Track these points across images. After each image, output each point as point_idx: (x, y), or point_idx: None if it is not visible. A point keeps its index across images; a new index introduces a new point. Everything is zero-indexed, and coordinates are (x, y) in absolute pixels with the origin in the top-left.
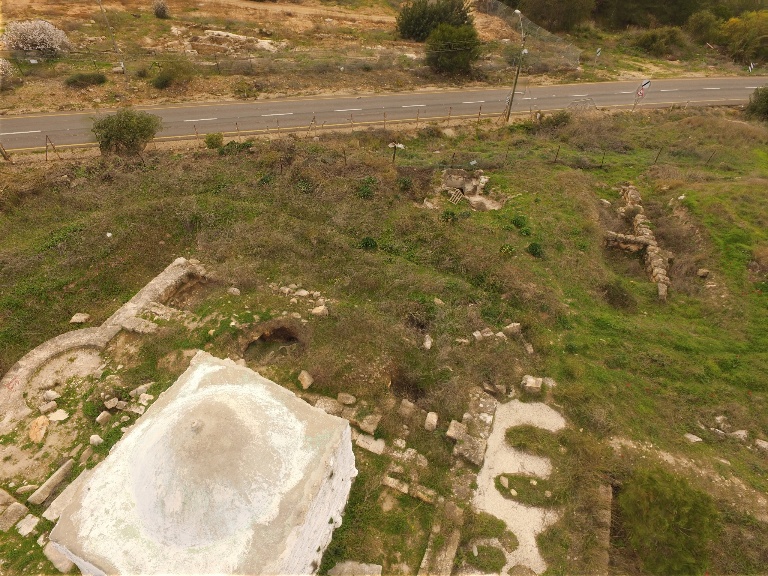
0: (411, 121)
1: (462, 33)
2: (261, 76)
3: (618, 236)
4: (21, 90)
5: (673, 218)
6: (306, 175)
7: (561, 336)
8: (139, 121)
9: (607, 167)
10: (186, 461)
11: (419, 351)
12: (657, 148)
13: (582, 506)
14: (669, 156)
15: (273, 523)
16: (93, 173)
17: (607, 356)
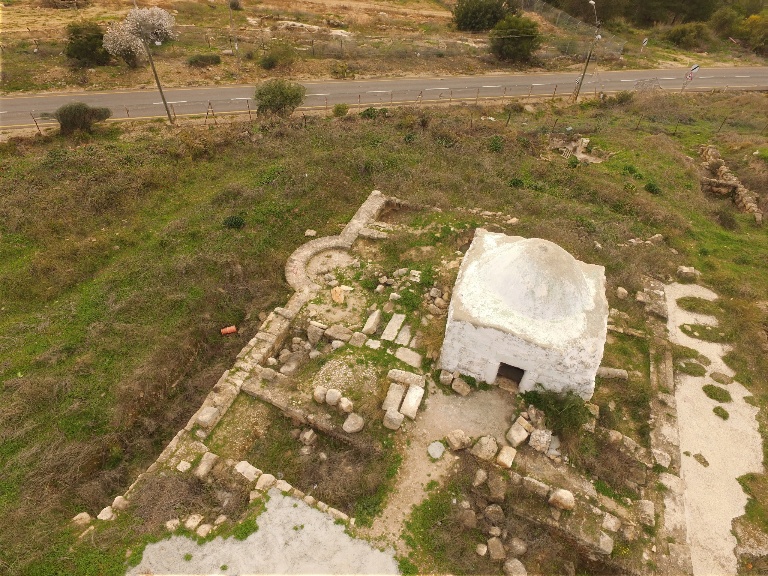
0: (495, 98)
1: (526, 23)
2: (351, 60)
3: (712, 180)
4: None
5: (750, 170)
6: (445, 133)
7: (693, 245)
8: (291, 90)
9: (680, 134)
10: (545, 266)
11: (594, 251)
12: (716, 120)
13: (749, 340)
14: (728, 127)
15: (594, 311)
16: (266, 131)
17: (734, 256)
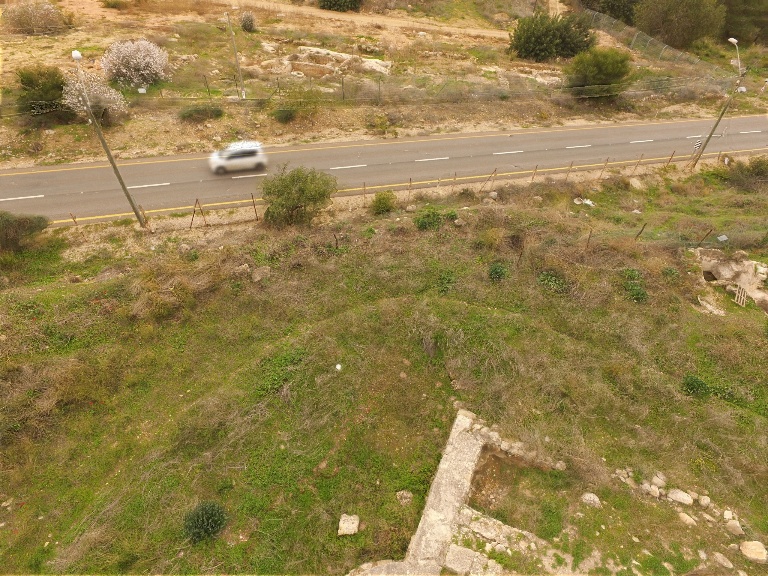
0: (588, 168)
1: (616, 58)
2: None
3: None
4: (131, 126)
5: None
6: (553, 267)
7: None
8: (316, 184)
9: None
10: None
11: None
12: None
13: None
14: None
15: None
16: (276, 259)
17: None
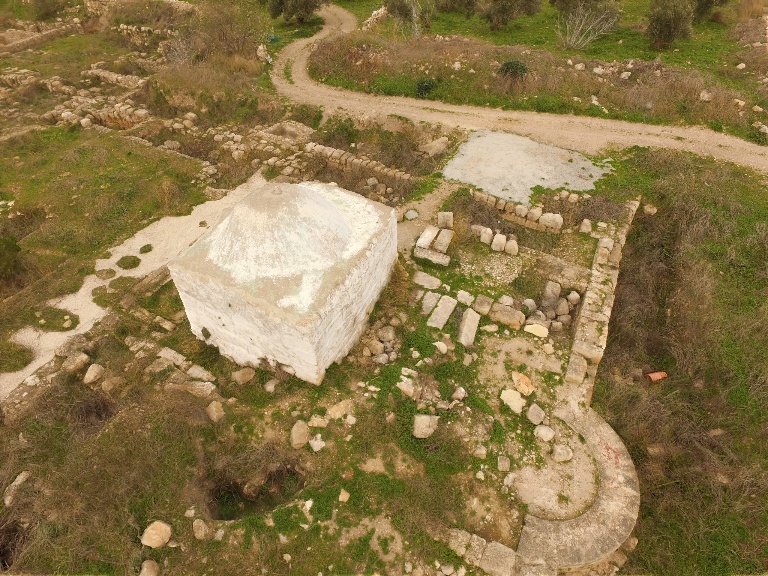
0: None
1: None
2: None
3: None
4: None
5: None
6: None
7: None
8: None
9: None
10: None
11: None
12: None
13: None
14: None
15: None
16: None
17: None
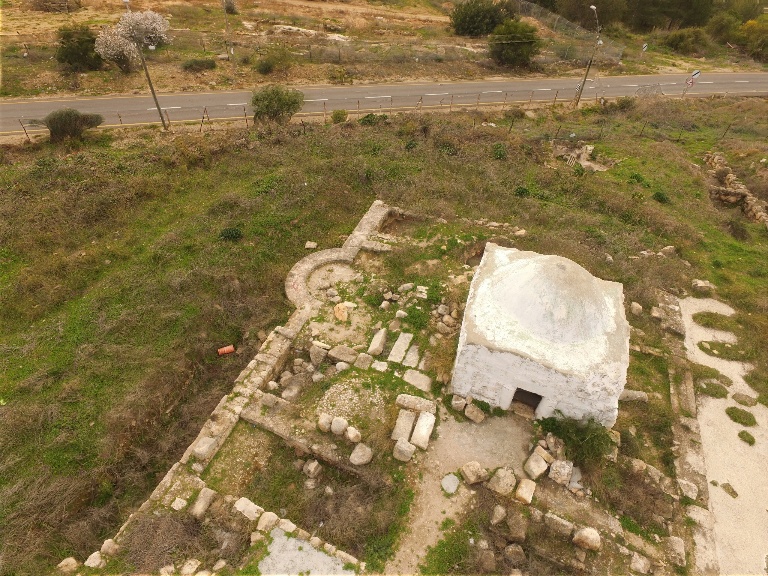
0: (496, 104)
1: (525, 28)
2: (348, 65)
3: (720, 189)
4: None
5: (757, 178)
6: (447, 140)
7: (706, 256)
8: (289, 96)
9: (684, 141)
10: (565, 286)
11: (605, 263)
12: (719, 127)
13: None
14: (731, 133)
15: (616, 332)
16: (263, 138)
17: (749, 268)
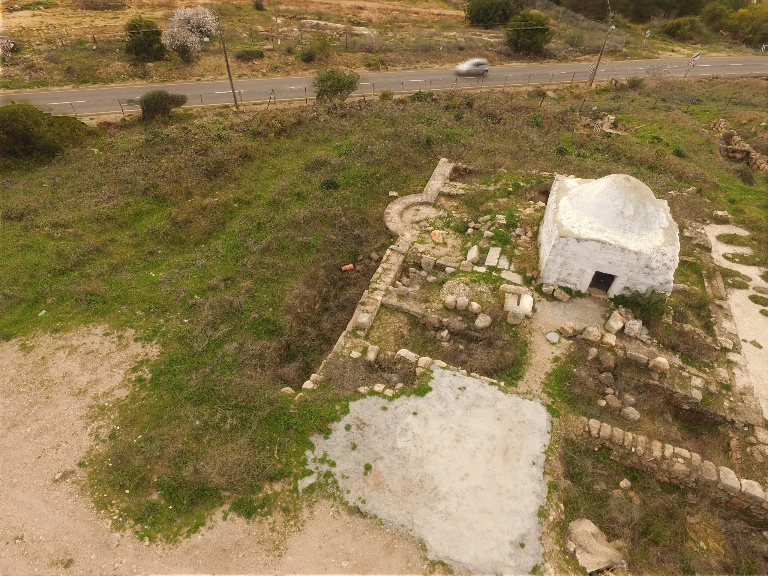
0: (519, 85)
1: (539, 18)
2: (381, 53)
3: (728, 147)
4: (203, 62)
5: (758, 139)
6: (490, 112)
7: (722, 196)
8: (347, 76)
9: (692, 112)
10: (631, 192)
11: None
12: (721, 101)
13: None
14: (732, 106)
15: (669, 228)
16: (331, 112)
17: (758, 203)
